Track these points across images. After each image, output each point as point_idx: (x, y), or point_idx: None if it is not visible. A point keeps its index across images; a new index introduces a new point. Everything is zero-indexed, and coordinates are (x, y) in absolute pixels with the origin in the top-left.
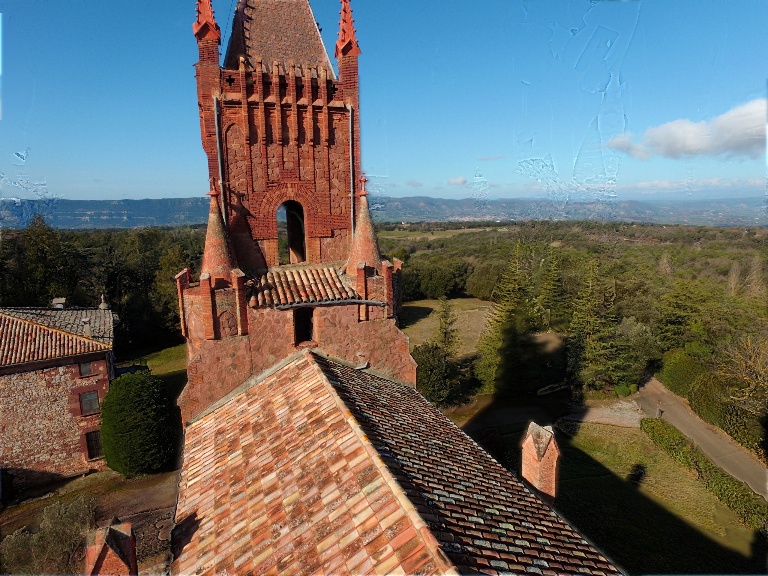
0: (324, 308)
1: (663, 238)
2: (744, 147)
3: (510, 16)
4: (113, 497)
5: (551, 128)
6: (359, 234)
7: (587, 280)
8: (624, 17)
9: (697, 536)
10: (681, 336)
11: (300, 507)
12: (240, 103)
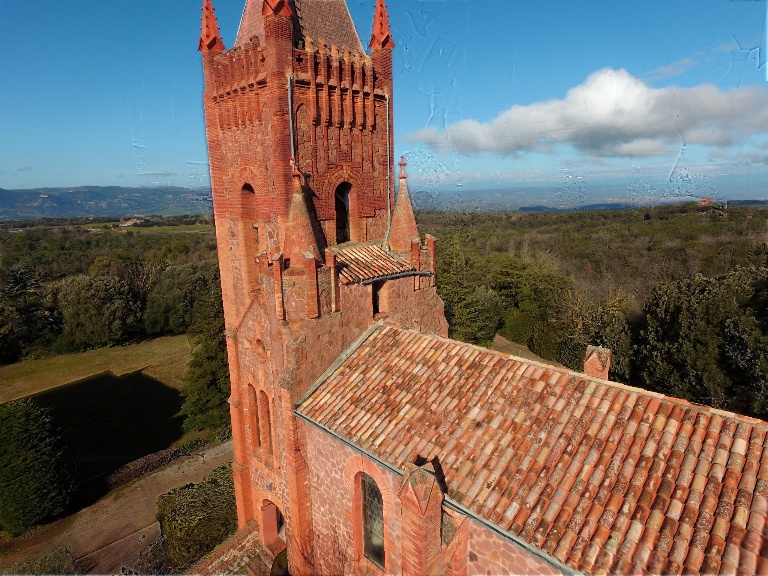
0: (393, 281)
1: (484, 220)
2: (541, 147)
3: (364, 15)
4: (7, 562)
5: None
6: (403, 213)
7: (452, 257)
8: (460, 32)
9: None
10: (512, 298)
11: (539, 419)
12: (309, 84)
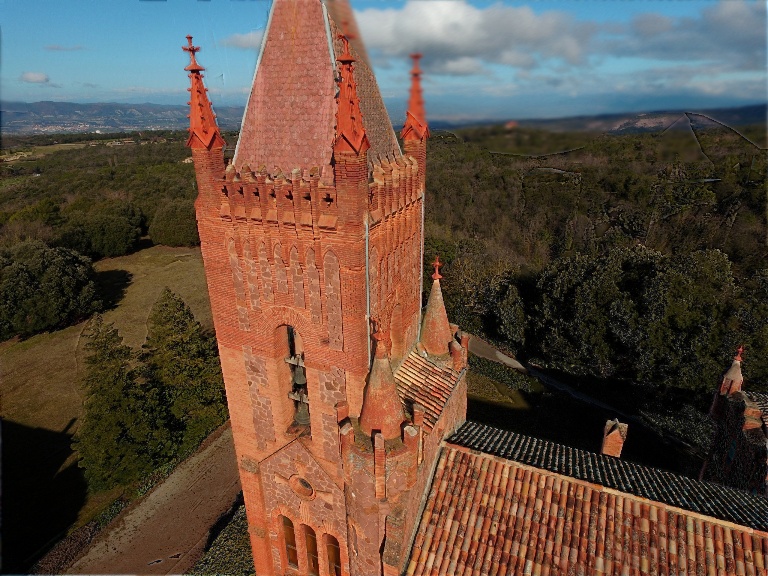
0: None
1: None
2: None
3: None
4: None
5: (225, 57)
6: (440, 315)
7: None
8: None
9: (506, 410)
10: None
11: (663, 567)
12: (380, 221)
